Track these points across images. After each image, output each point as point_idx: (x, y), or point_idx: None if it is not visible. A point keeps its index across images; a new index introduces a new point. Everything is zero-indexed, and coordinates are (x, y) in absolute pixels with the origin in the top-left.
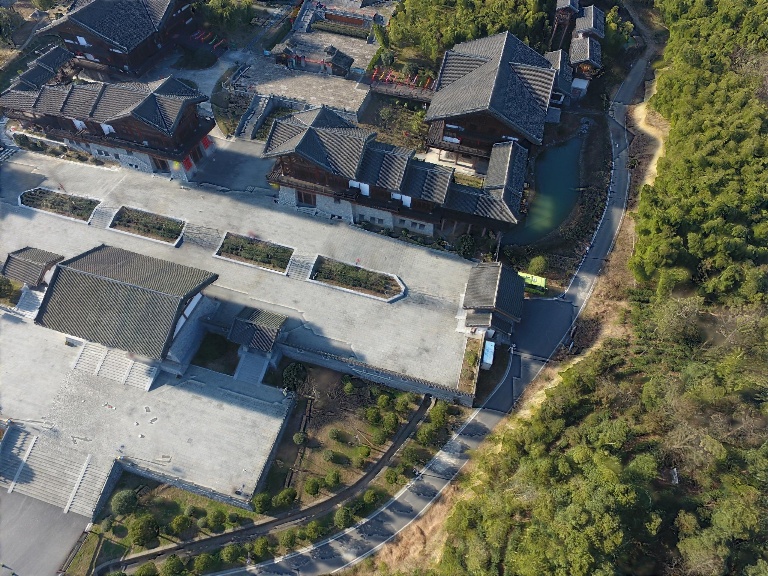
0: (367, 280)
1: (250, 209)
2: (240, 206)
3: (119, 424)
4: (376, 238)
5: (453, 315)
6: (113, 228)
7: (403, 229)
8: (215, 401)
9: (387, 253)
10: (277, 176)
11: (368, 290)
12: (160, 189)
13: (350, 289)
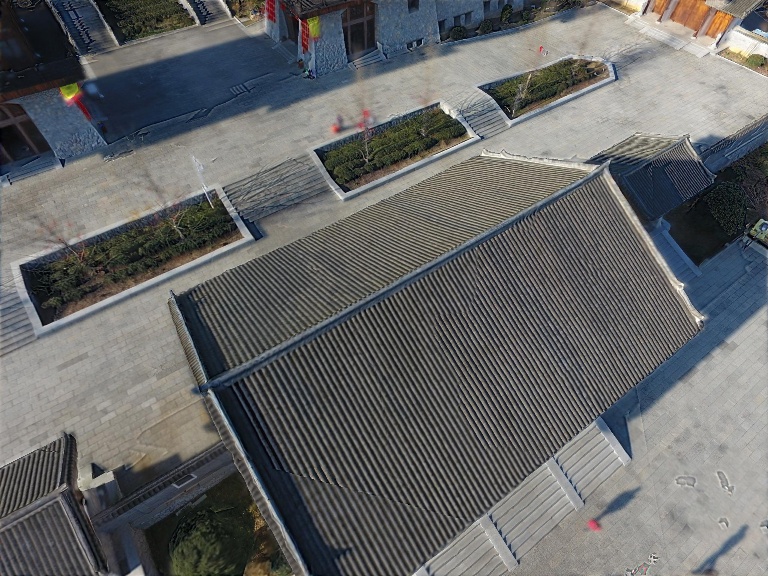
0: (562, 75)
1: (289, 107)
2: (267, 113)
3: (710, 568)
4: (486, 40)
5: (672, 49)
6: (58, 319)
7: (506, 7)
8: (710, 348)
9: (522, 45)
10: (307, 2)
11: (578, 85)
12: (63, 188)
13: (565, 96)
